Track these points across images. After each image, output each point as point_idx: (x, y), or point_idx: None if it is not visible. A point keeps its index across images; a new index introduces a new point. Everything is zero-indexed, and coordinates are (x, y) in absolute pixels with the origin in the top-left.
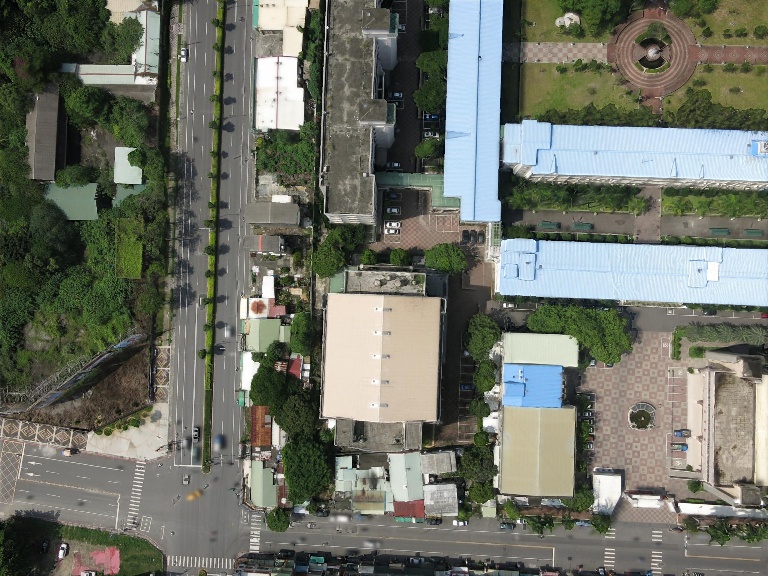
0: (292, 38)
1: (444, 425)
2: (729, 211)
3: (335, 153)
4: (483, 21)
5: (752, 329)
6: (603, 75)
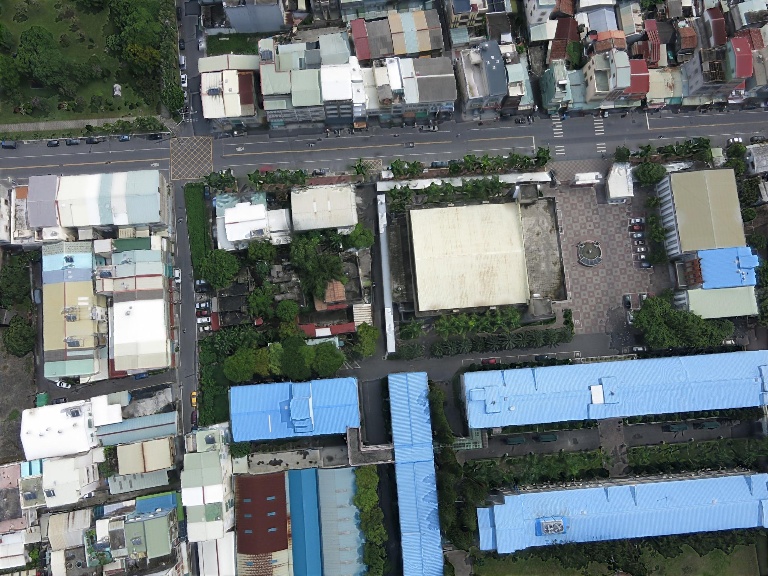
0: None
1: (766, 224)
2: None
3: None
4: None
5: None
6: None
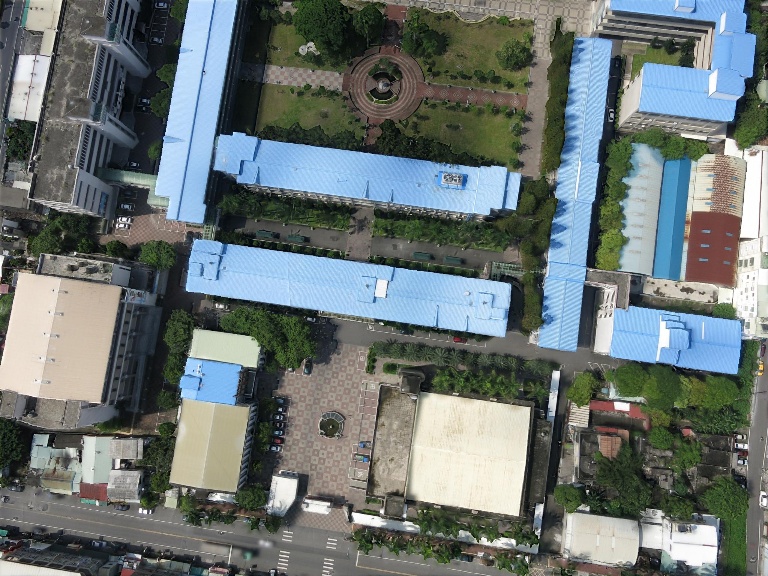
0: (52, 40)
1: (144, 414)
2: (415, 235)
3: (48, 144)
4: (211, 40)
5: (436, 350)
6: (337, 101)
